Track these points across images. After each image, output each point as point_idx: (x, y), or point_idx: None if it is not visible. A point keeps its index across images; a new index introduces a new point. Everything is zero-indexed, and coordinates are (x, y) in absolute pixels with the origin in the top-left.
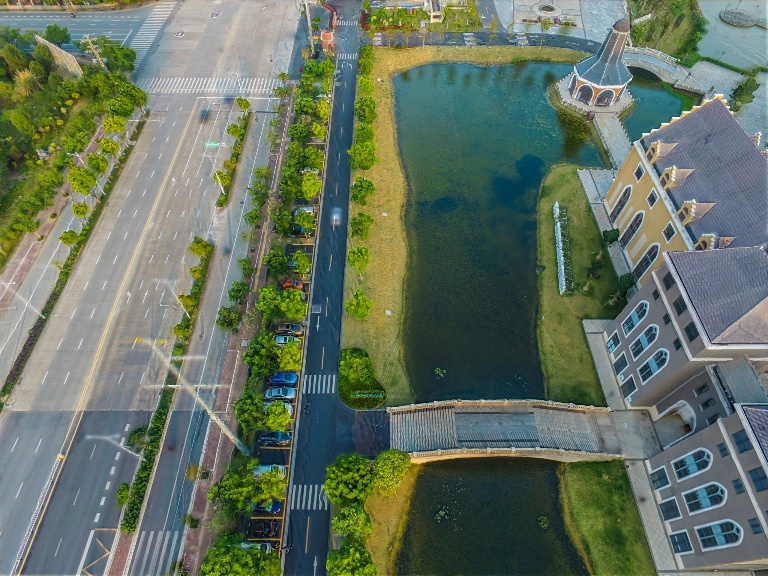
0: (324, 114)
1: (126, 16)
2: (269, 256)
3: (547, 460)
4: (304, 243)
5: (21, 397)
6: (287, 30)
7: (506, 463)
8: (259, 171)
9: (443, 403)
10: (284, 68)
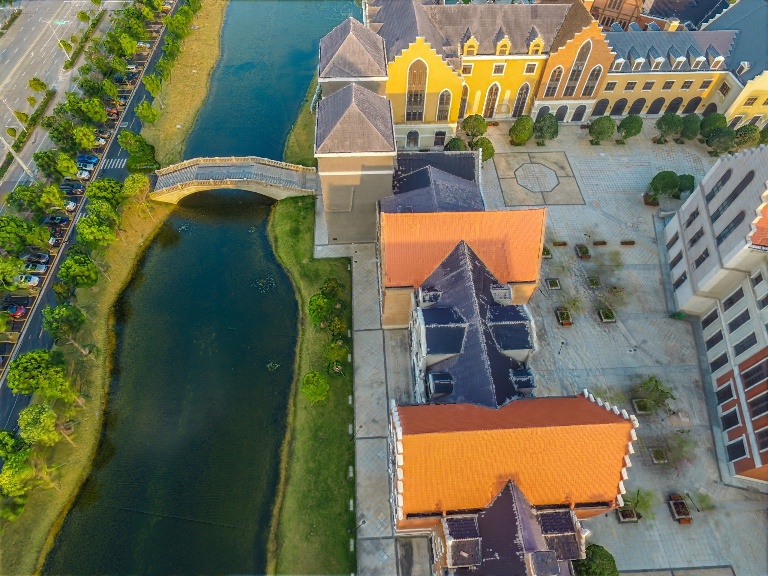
0: (158, 5)
1: None
2: (81, 81)
3: (261, 195)
4: (125, 88)
5: None
6: None
7: (238, 203)
8: (95, 40)
9: (191, 162)
10: None
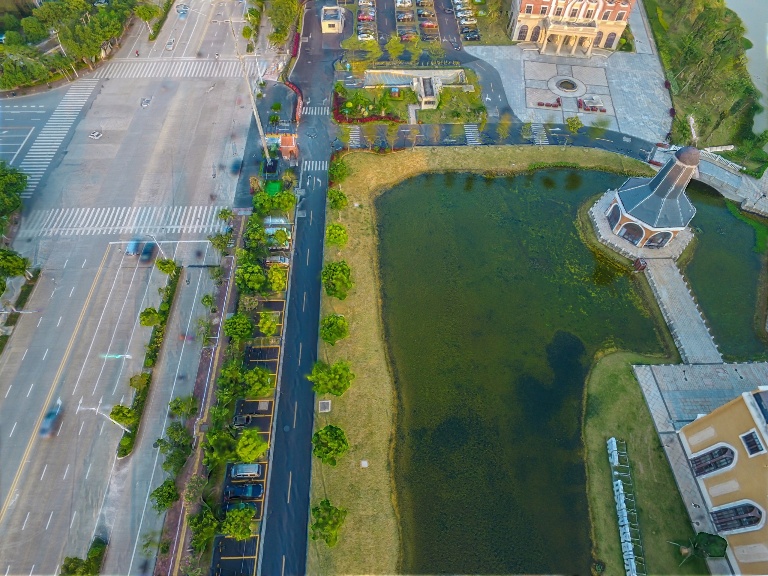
0: (278, 286)
1: (29, 105)
2: None
3: None
4: None
5: None
6: (237, 124)
7: None
8: (178, 405)
9: None
10: (230, 188)
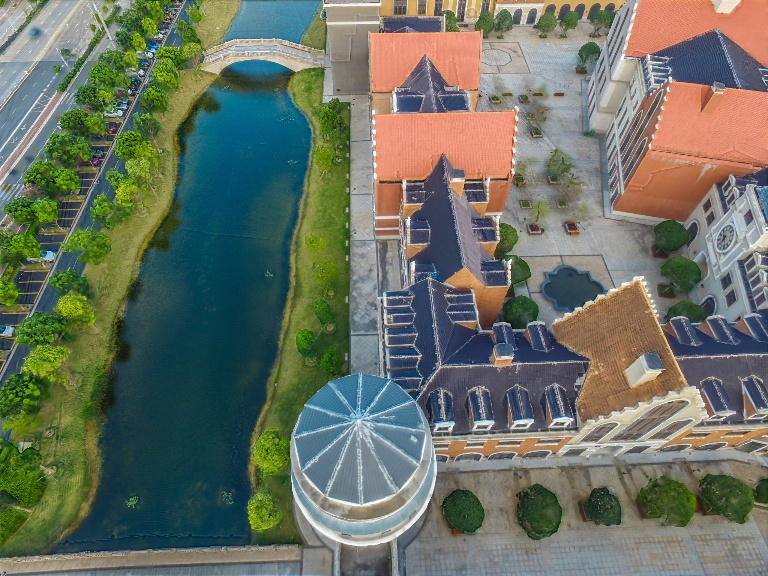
0: None
1: None
2: None
3: (282, 66)
4: (175, 4)
5: (4, 58)
6: None
7: (265, 74)
8: None
9: (230, 43)
10: None
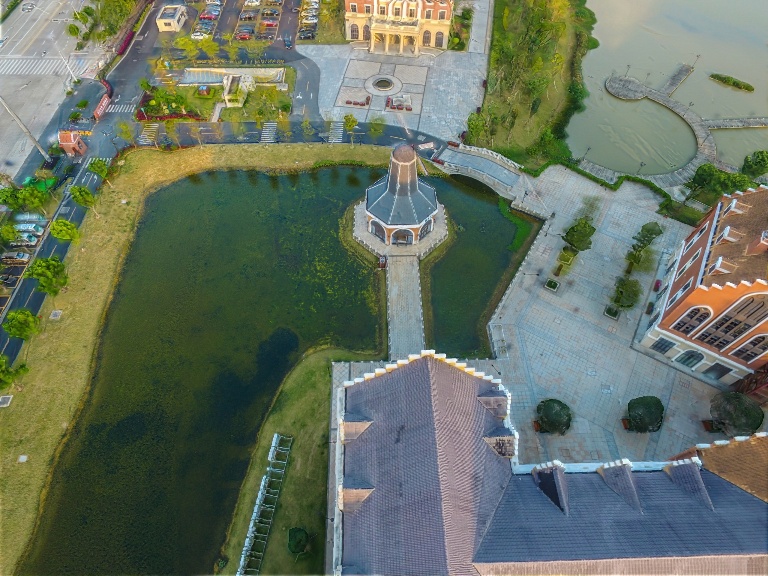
0: None
1: None
2: None
3: None
4: None
5: None
6: (37, 121)
7: None
8: None
9: None
10: None
